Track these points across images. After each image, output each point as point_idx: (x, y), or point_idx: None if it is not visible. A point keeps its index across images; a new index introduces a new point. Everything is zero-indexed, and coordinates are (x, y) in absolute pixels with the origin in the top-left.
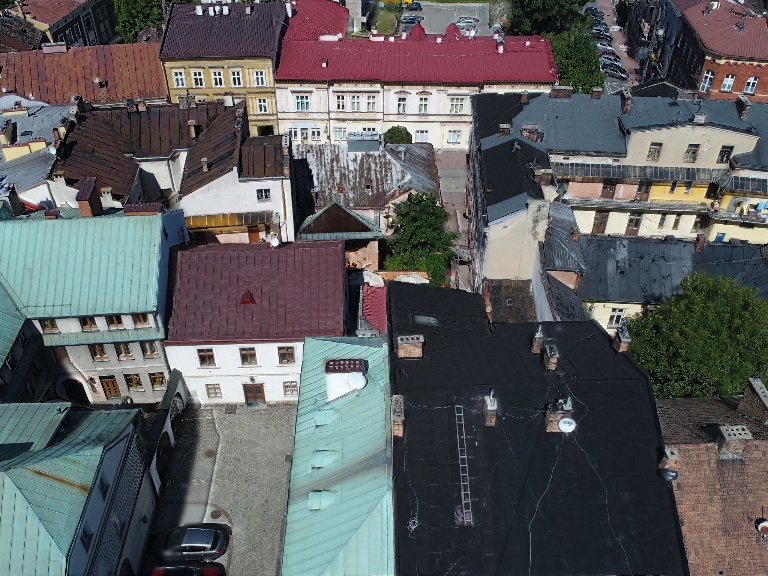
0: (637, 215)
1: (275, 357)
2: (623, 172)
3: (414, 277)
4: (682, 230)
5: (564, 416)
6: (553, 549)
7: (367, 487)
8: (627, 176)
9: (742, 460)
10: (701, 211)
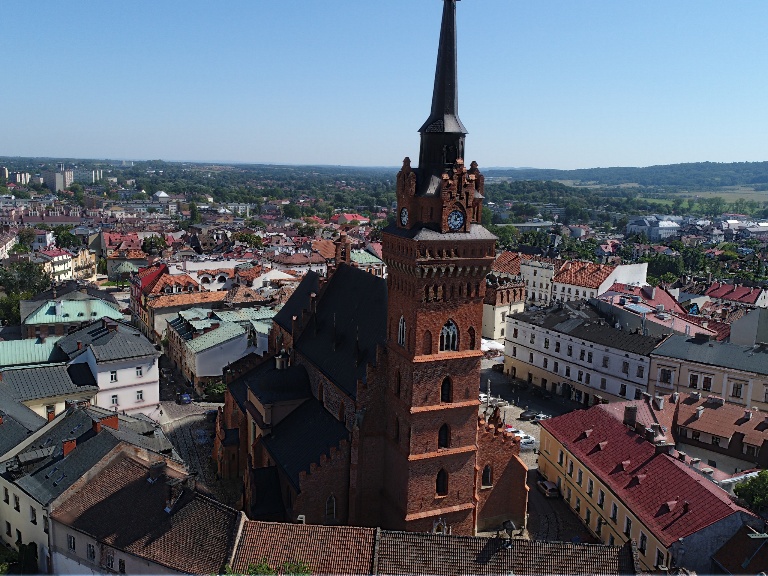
0: None
1: None
2: None
3: None
4: None
5: None
6: None
7: (95, 304)
8: None
9: None
10: None
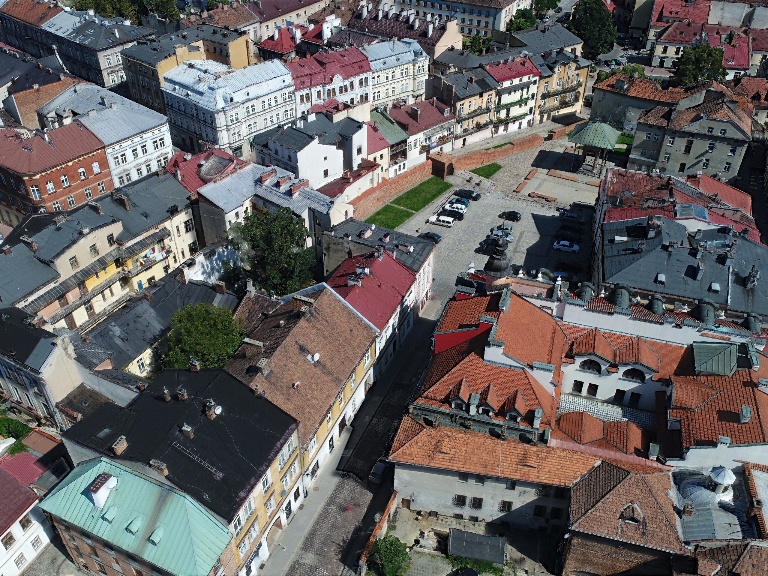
0: (88, 303)
1: (2, 549)
2: (66, 286)
3: (1, 443)
4: (117, 294)
5: (215, 408)
6: (255, 454)
7: (173, 508)
8: (70, 287)
9: (271, 371)
10: (121, 277)
